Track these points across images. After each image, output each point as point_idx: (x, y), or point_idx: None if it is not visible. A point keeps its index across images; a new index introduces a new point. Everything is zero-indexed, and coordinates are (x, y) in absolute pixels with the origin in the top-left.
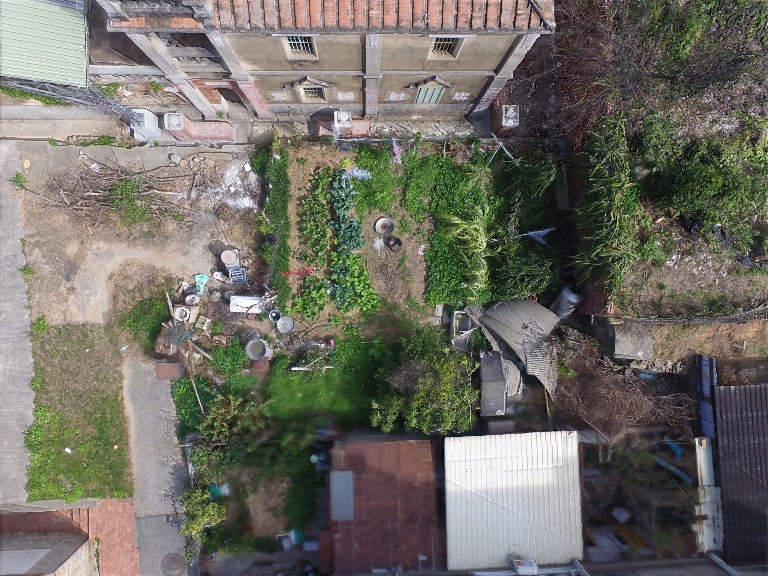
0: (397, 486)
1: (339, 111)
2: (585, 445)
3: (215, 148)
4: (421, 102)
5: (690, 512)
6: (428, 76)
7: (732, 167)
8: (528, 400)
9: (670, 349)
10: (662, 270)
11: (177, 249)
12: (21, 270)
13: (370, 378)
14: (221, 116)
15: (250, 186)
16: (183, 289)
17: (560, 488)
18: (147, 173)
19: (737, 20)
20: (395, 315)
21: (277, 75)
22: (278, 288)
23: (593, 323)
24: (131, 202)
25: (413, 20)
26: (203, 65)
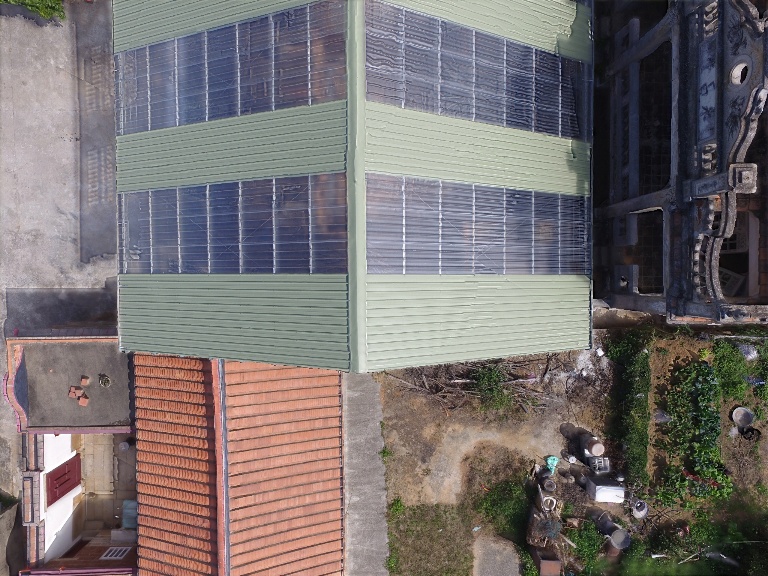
0: None
1: None
2: None
3: None
4: None
5: None
6: None
7: None
8: None
9: None
10: None
11: (529, 431)
12: (381, 453)
13: (722, 563)
14: None
15: (604, 371)
16: (535, 471)
17: None
18: None
19: None
20: (744, 500)
21: None
22: (638, 476)
23: None
24: (500, 392)
25: None
26: None
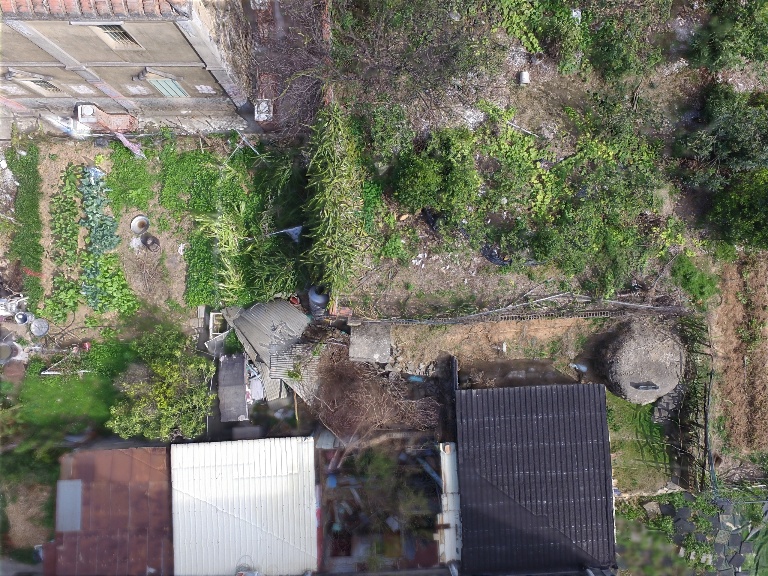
0: (128, 495)
1: (82, 105)
2: (323, 451)
3: None
4: (171, 96)
5: (433, 521)
6: (140, 68)
7: (453, 162)
8: None
9: (420, 351)
10: (409, 269)
11: None
12: None
13: None
14: None
15: (5, 183)
16: None
17: (295, 496)
18: None
19: (479, 10)
20: (156, 317)
21: None
22: (28, 289)
23: None
24: None
25: (32, 6)
26: None
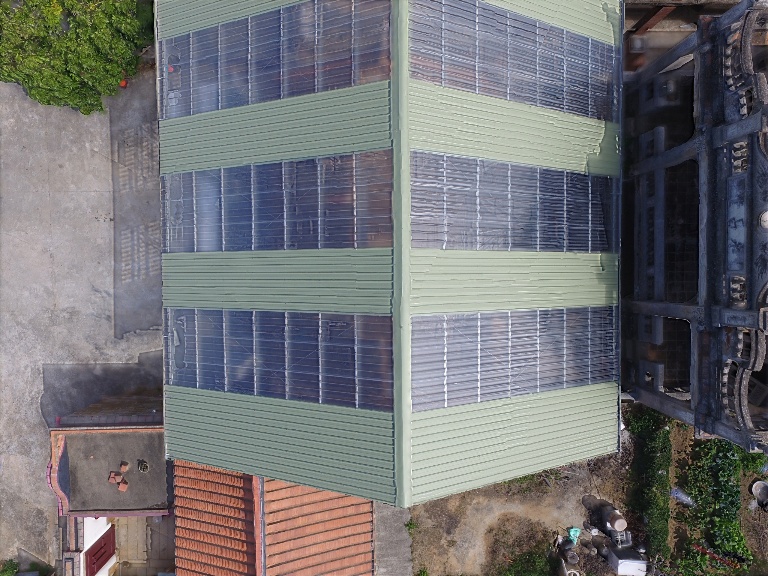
0: None
1: None
2: None
3: None
4: None
5: None
6: None
7: None
8: None
9: None
10: None
11: (552, 503)
12: (408, 526)
13: None
14: None
15: (625, 445)
16: (558, 542)
17: None
18: None
19: None
20: (764, 571)
21: None
22: (660, 549)
23: None
24: None
25: None
26: None
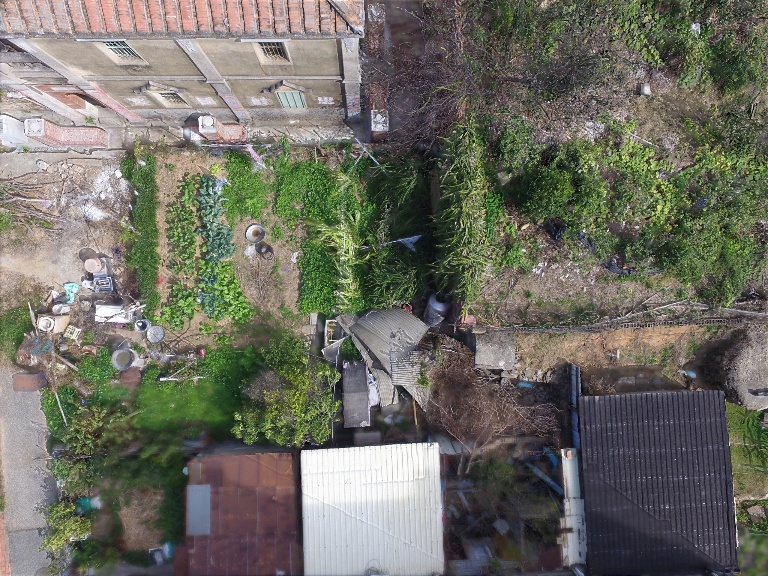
0: (256, 500)
1: (203, 116)
2: (448, 457)
3: (85, 154)
4: (289, 107)
5: (556, 525)
6: (276, 81)
7: (585, 173)
8: (407, 410)
9: (539, 358)
10: (529, 278)
11: (47, 257)
12: None
13: None
14: (91, 121)
15: (120, 193)
16: (53, 298)
17: (421, 501)
18: (15, 180)
19: (601, 22)
20: (269, 324)
21: (118, 80)
22: (146, 297)
23: (465, 332)
24: None
25: (213, 24)
26: (37, 70)
